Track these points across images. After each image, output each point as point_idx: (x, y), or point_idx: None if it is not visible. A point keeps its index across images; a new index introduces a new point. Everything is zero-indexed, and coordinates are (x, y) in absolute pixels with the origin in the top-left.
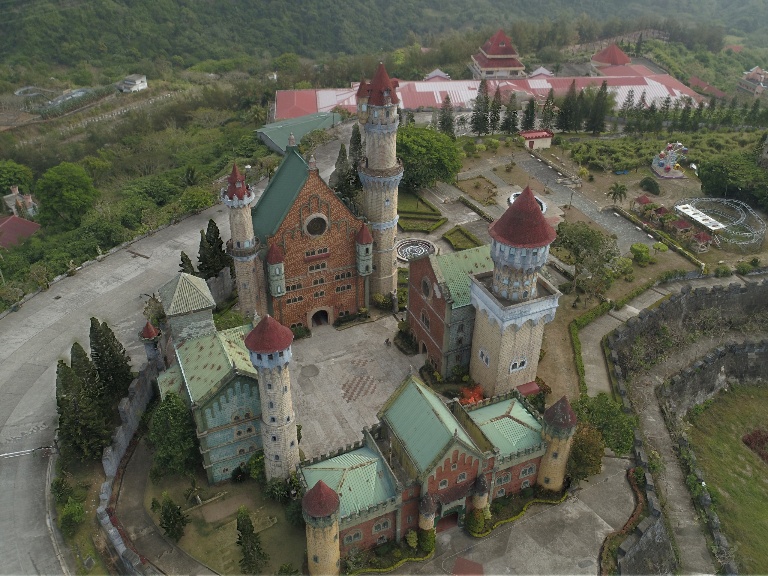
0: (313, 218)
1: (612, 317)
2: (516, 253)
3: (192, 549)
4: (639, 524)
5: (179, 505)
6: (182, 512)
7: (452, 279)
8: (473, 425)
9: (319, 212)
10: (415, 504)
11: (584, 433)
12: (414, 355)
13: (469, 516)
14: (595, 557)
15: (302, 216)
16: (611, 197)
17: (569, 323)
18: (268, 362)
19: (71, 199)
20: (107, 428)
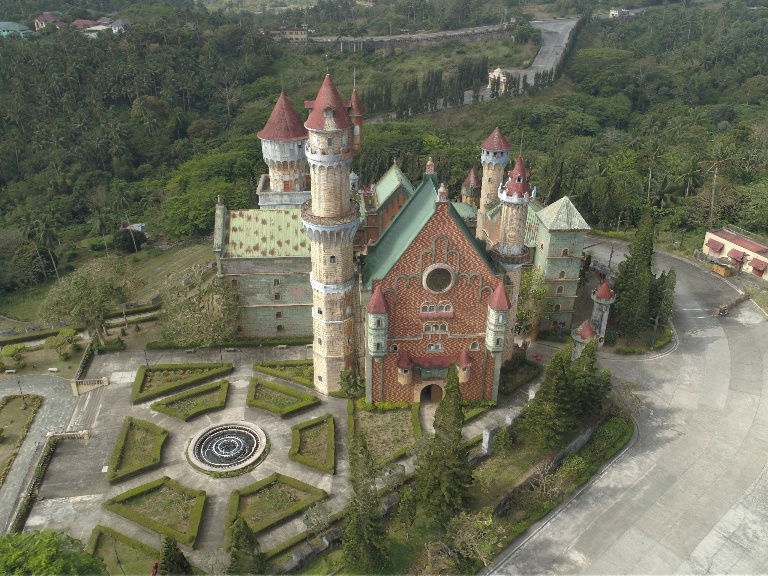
0: None
1: None
2: None
3: None
4: None
5: None
6: None
7: None
8: None
9: None
10: None
11: None
12: None
13: None
14: None
15: None
16: None
17: None
18: None
19: None
20: None
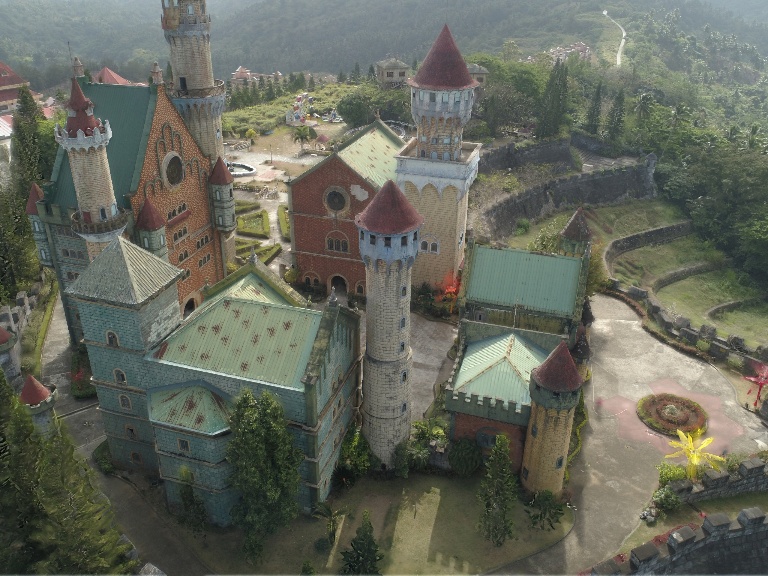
0: (170, 158)
1: None
2: (461, 98)
3: None
4: (653, 303)
5: None
6: (327, 568)
7: None
8: None
9: (172, 150)
10: None
11: None
12: (326, 299)
13: None
14: (658, 342)
15: (158, 158)
16: (300, 142)
17: None
18: (413, 246)
19: None
20: None
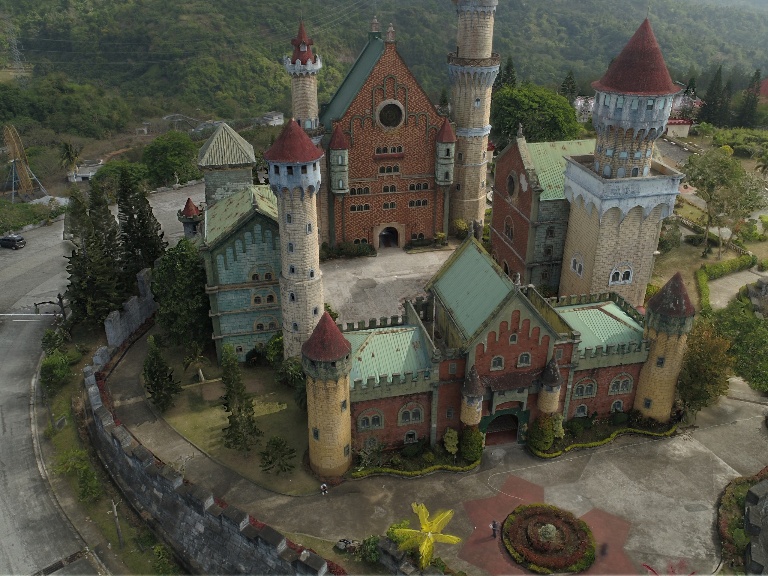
0: (387, 104)
1: (754, 274)
2: (624, 105)
3: (178, 422)
4: None
5: (171, 367)
6: (179, 387)
7: (543, 169)
8: (549, 311)
9: (395, 98)
10: (458, 390)
11: (704, 334)
12: None
13: (532, 426)
14: (711, 502)
15: (374, 100)
16: (760, 170)
17: (695, 270)
18: (287, 178)
19: (174, 164)
20: (120, 294)
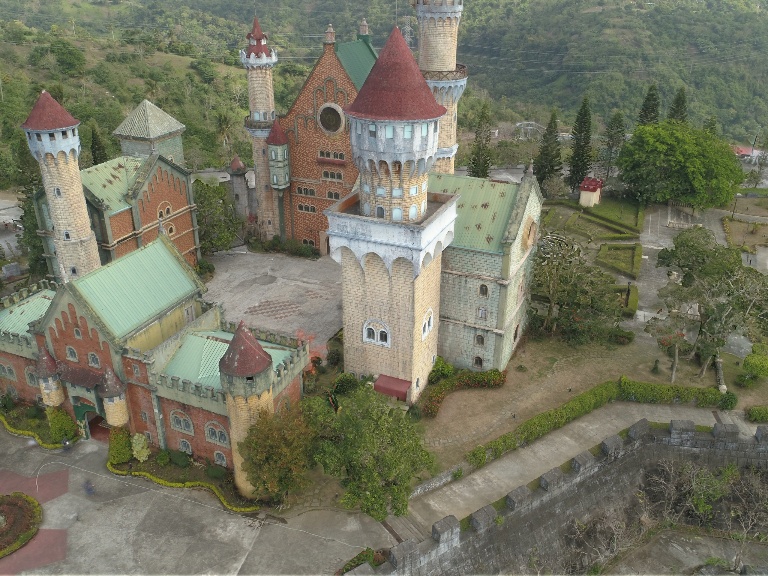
0: (326, 107)
1: (713, 417)
2: (352, 127)
3: None
4: None
5: None
6: None
7: None
8: None
9: (335, 102)
10: None
11: (264, 406)
12: None
13: None
14: None
15: (317, 101)
16: None
17: (613, 381)
18: None
19: None
20: None
